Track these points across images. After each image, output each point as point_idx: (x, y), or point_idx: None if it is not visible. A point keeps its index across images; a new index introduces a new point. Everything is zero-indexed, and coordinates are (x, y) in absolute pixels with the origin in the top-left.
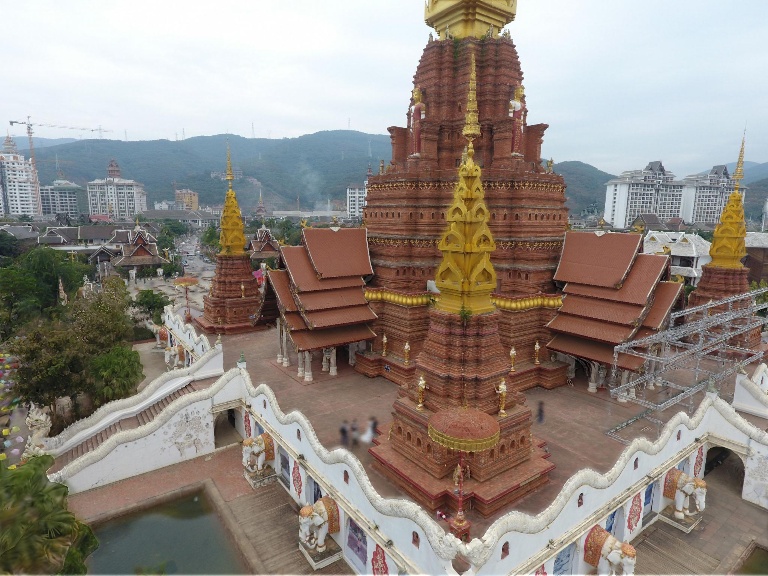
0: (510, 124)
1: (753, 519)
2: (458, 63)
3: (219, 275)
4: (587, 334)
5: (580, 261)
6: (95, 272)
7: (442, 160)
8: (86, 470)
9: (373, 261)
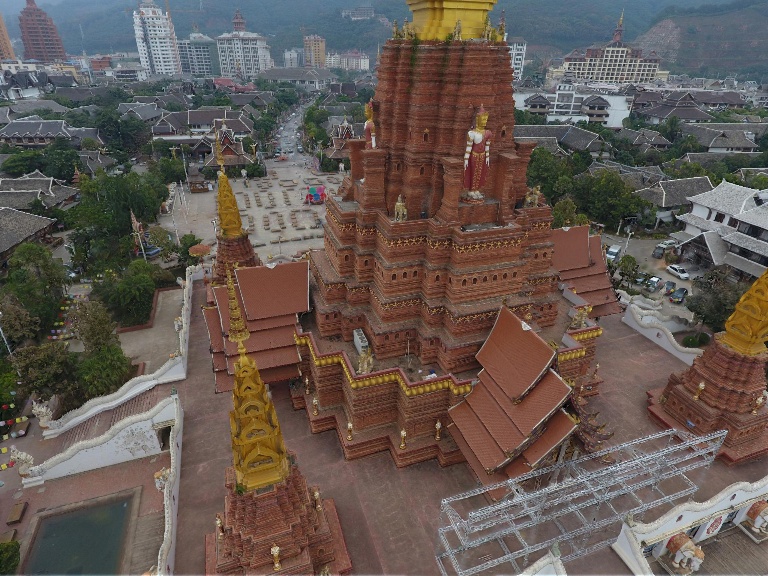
0: (457, 169)
1: None
2: (414, 74)
3: (219, 254)
4: (470, 441)
5: (502, 349)
6: None
7: (388, 195)
8: (59, 465)
9: (313, 295)
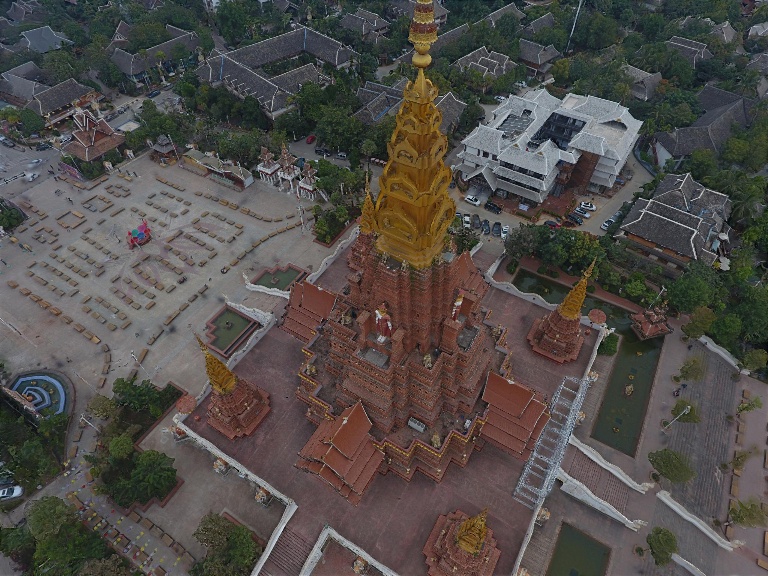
0: None
1: (563, 504)
2: (415, 287)
3: (222, 403)
4: (503, 443)
5: (498, 393)
6: None
7: (407, 346)
8: None
9: (368, 414)
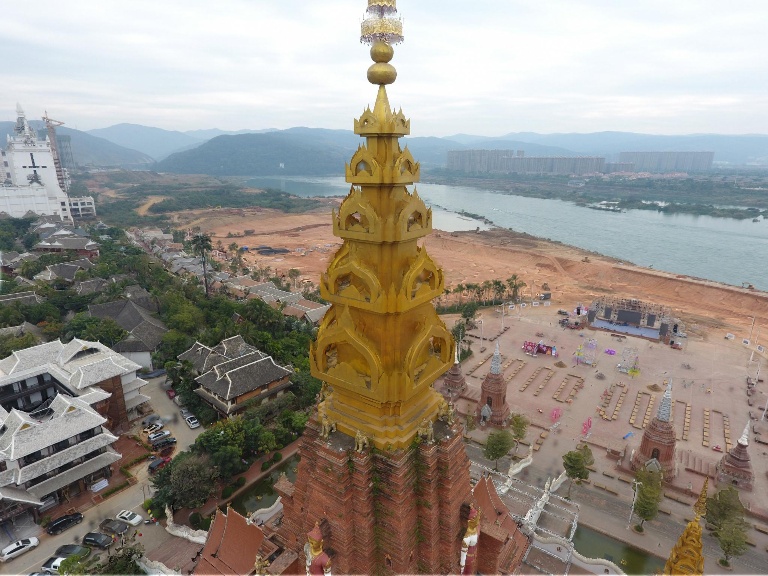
0: None
1: None
2: None
3: None
4: (519, 554)
5: None
6: None
7: None
8: None
9: None
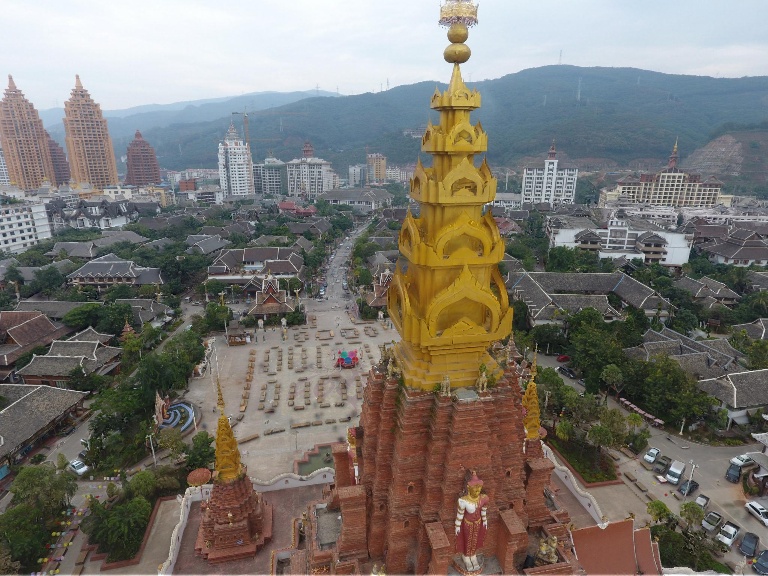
0: None
1: None
2: (398, 418)
3: (213, 494)
4: None
5: None
6: None
7: (370, 536)
8: None
9: None
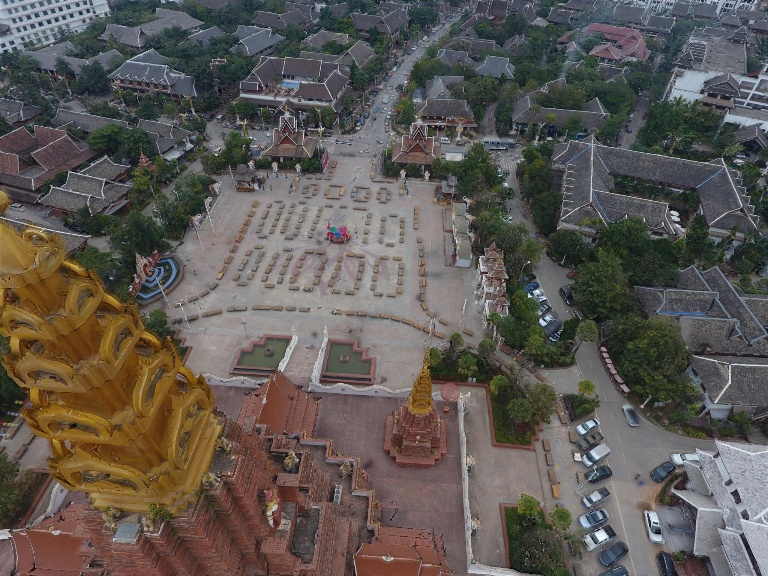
0: None
1: None
2: None
3: None
4: None
5: None
6: (247, 160)
7: None
8: None
9: None
